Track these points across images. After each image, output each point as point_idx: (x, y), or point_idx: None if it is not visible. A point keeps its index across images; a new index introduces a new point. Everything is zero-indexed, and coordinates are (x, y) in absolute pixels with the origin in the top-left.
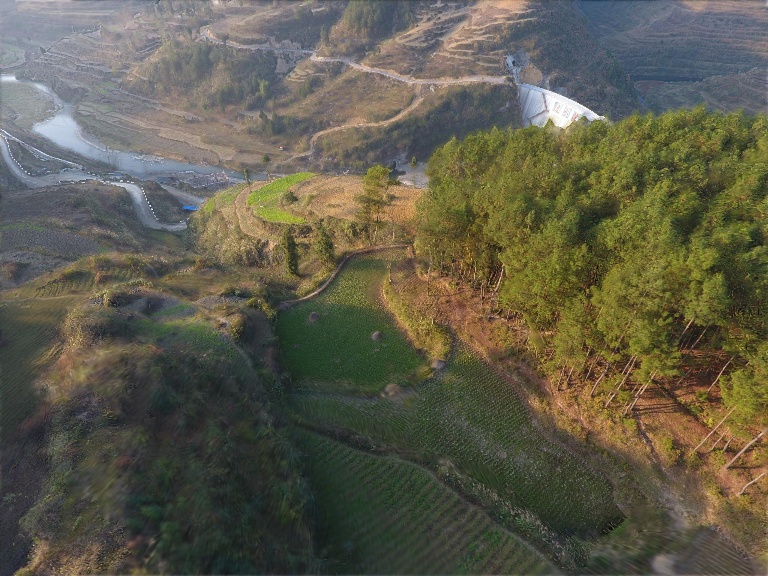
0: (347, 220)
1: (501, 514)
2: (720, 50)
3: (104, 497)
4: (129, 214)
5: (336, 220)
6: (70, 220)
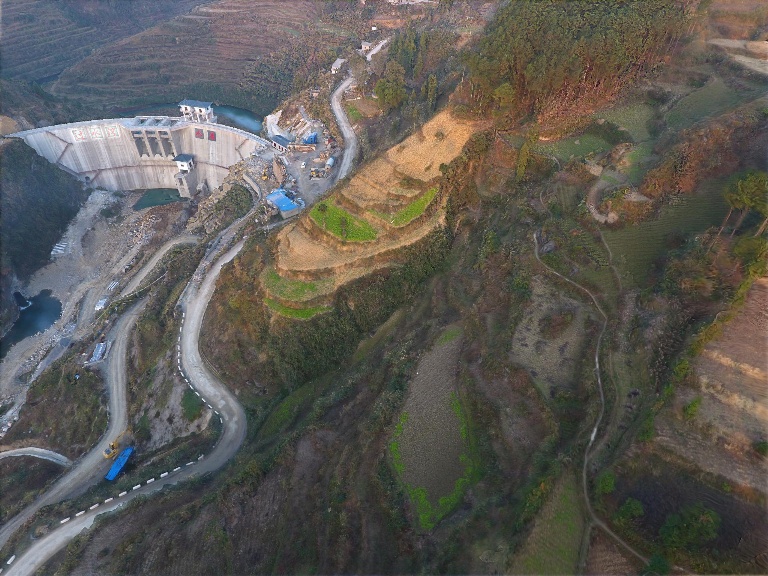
0: (460, 156)
1: (674, 102)
2: (19, 51)
3: (765, 99)
4: (202, 478)
5: (455, 163)
6: (316, 457)
